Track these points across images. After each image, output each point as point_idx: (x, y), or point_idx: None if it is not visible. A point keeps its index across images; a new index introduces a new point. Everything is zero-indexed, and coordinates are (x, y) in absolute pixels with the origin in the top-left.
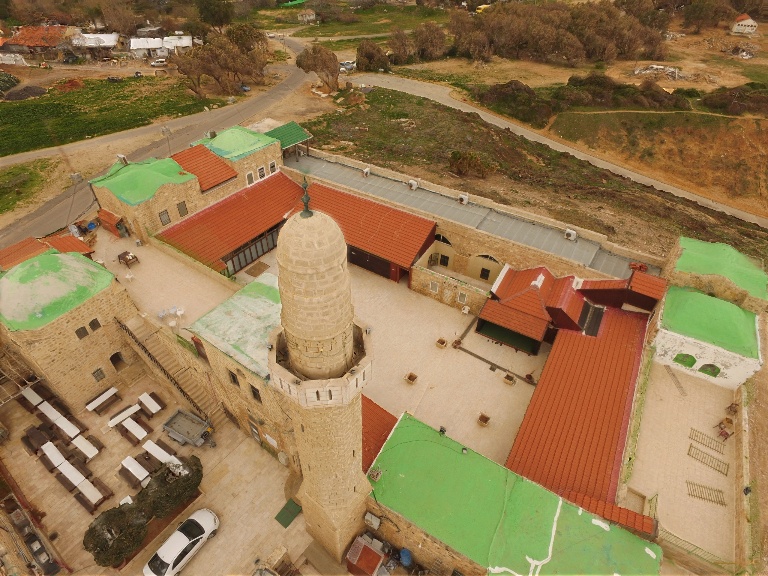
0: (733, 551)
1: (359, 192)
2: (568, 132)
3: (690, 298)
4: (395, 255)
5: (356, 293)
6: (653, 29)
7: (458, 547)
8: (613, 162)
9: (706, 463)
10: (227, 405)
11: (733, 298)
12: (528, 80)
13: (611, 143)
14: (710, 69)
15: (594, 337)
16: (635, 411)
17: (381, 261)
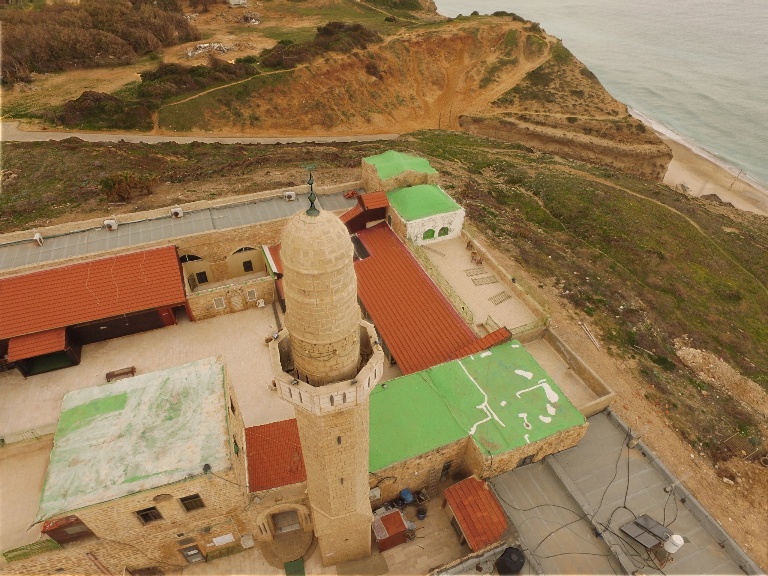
0: (533, 315)
1: (57, 262)
2: (178, 124)
3: (405, 194)
4: (160, 298)
5: (144, 362)
6: (174, 13)
7: (444, 442)
8: (234, 136)
9: (486, 283)
10: (135, 564)
11: (421, 182)
12: (96, 88)
13: (221, 121)
14: (241, 38)
15: (369, 257)
16: (437, 281)
17: (145, 314)
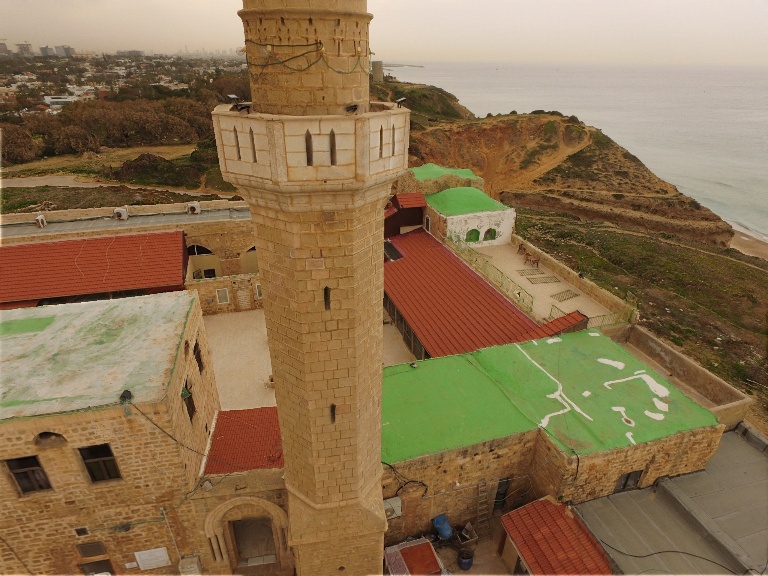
0: (611, 313)
1: (49, 235)
2: (224, 185)
3: (445, 192)
4: (154, 279)
5: None
6: None
7: (501, 433)
8: None
9: (545, 282)
10: None
11: None
12: None
13: None
14: None
15: (402, 258)
16: (484, 273)
17: None
